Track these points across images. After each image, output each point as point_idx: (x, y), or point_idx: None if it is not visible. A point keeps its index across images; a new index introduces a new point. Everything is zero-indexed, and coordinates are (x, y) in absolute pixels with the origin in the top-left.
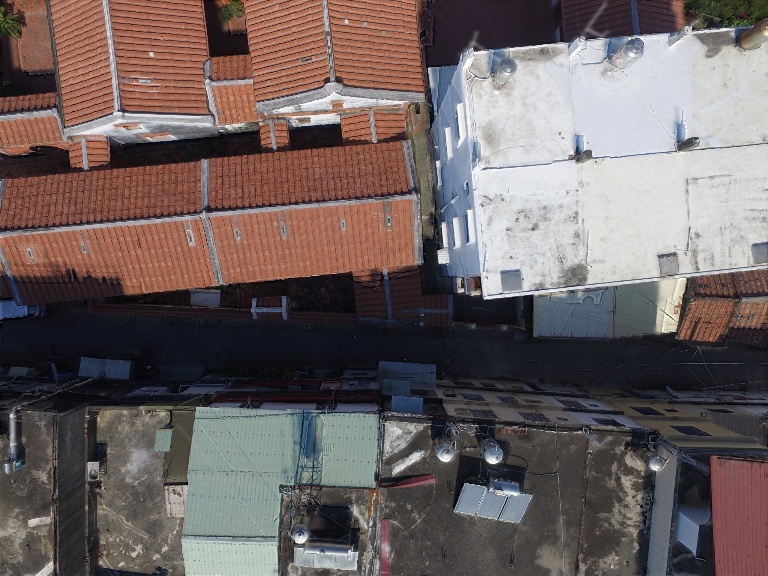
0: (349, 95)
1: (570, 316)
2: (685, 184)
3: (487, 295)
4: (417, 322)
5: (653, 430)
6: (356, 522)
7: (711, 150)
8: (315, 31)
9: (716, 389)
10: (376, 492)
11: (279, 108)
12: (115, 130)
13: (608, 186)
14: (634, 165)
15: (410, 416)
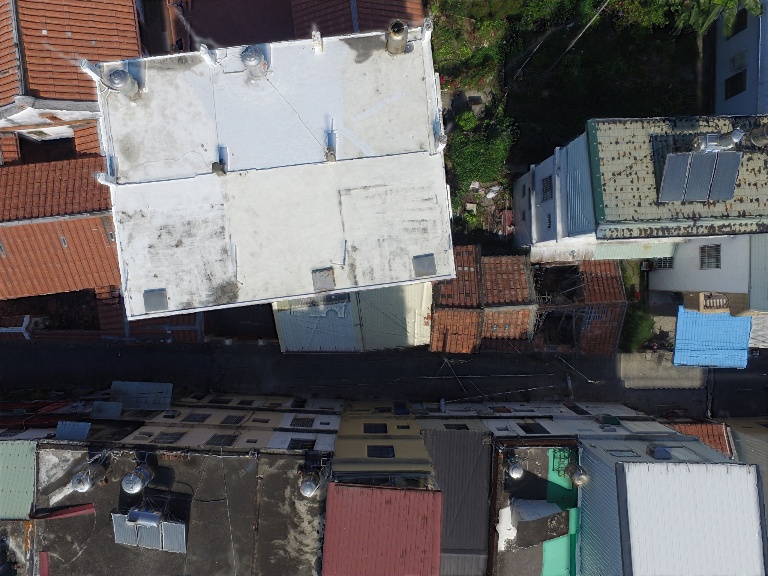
0: (48, 108)
1: (315, 330)
2: (337, 195)
3: (131, 316)
4: (163, 339)
5: (327, 452)
6: (13, 555)
7: (363, 159)
8: (10, 43)
9: (498, 400)
10: (32, 524)
11: None
12: None
13: (255, 199)
14: (282, 177)
15: (67, 443)
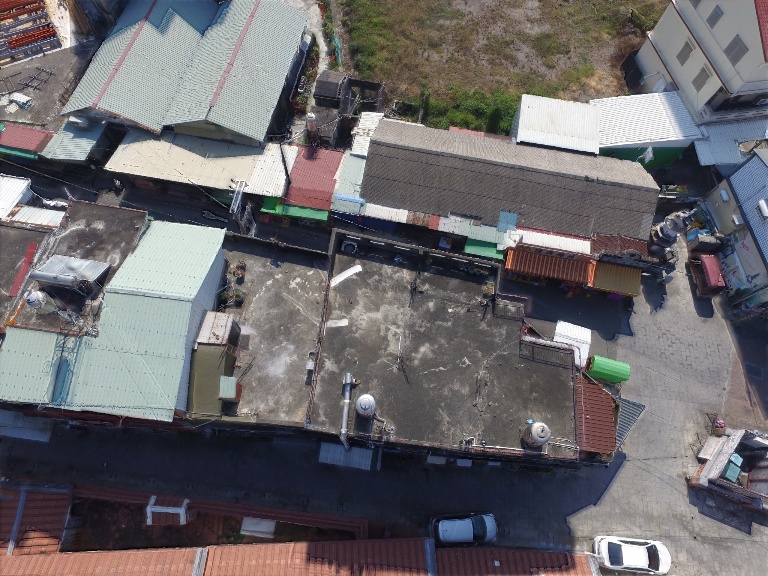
0: None
1: None
2: None
3: None
4: (6, 482)
5: None
6: None
7: None
8: None
9: None
10: (8, 322)
11: None
12: None
13: None
14: None
15: None
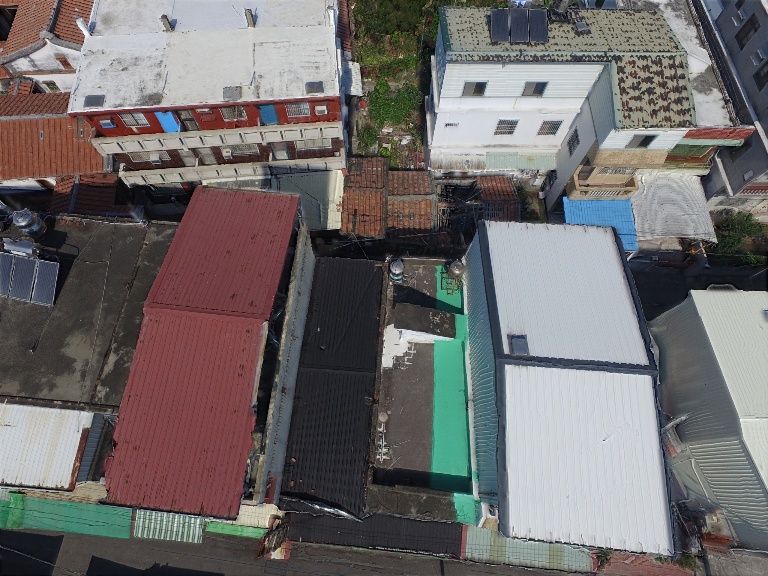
0: (62, 45)
1: None
2: (252, 46)
3: (70, 110)
4: None
5: None
6: None
7: (275, 28)
8: None
9: None
10: None
11: (13, 59)
12: None
13: (190, 46)
14: (213, 35)
15: None
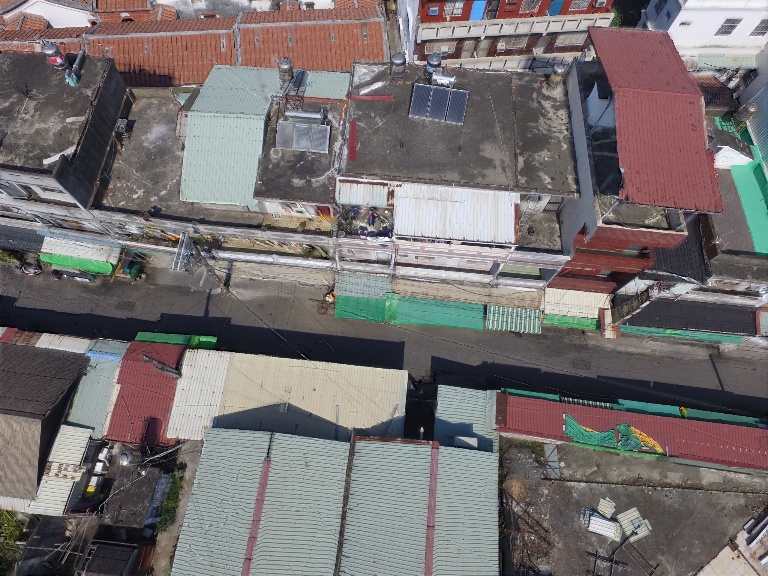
0: None
1: None
2: None
3: None
4: None
5: None
6: (330, 123)
7: None
8: None
9: None
10: (346, 103)
11: None
12: (184, 1)
13: None
14: None
15: (374, 63)
